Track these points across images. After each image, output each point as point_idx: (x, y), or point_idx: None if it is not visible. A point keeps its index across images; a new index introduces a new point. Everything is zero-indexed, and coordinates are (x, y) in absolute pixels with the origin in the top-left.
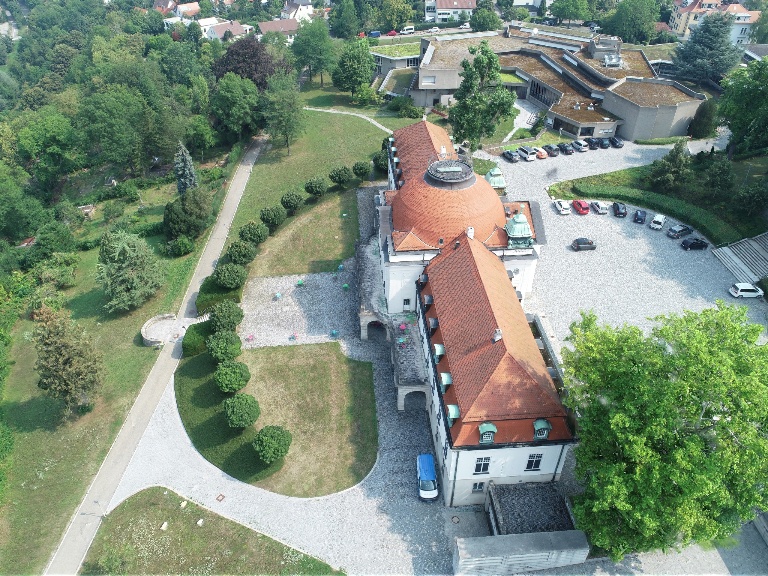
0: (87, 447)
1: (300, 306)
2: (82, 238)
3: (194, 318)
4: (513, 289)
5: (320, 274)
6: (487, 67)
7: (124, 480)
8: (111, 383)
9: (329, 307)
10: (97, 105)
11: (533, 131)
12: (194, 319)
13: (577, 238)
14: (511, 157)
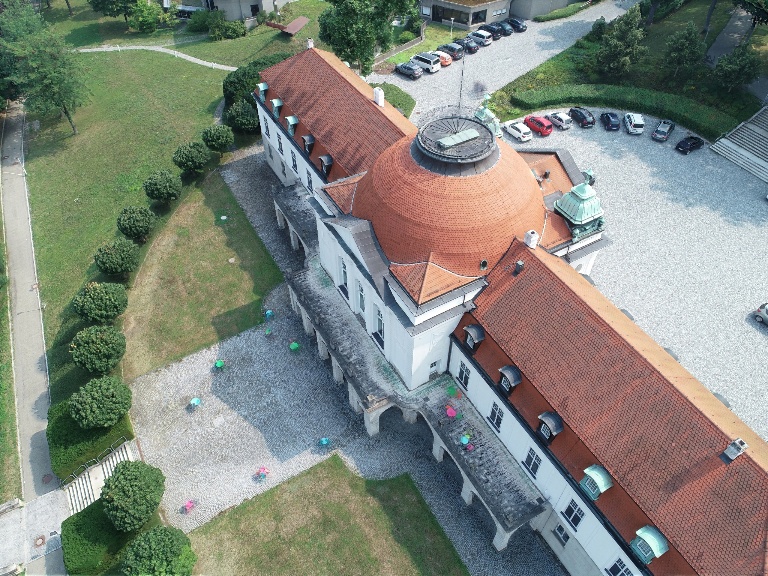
0: None
1: (240, 408)
2: None
3: (57, 490)
4: (621, 312)
5: (241, 335)
6: None
7: None
8: None
9: (287, 393)
10: None
11: (410, 28)
12: (58, 492)
13: None
14: (411, 72)
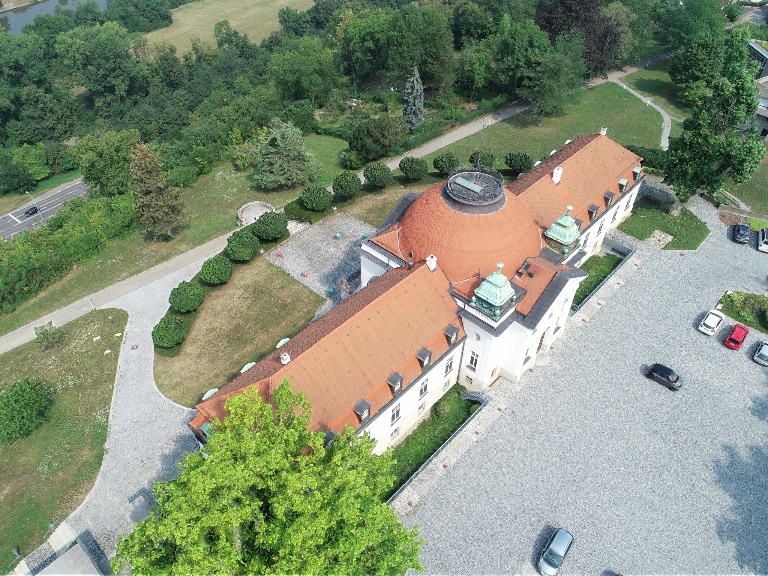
0: (137, 262)
1: (343, 254)
2: (329, 124)
3: None
4: (420, 344)
5: None
6: (734, 99)
7: (125, 296)
8: (195, 231)
9: None
10: (405, 15)
11: None
12: None
13: (673, 365)
14: (736, 233)
